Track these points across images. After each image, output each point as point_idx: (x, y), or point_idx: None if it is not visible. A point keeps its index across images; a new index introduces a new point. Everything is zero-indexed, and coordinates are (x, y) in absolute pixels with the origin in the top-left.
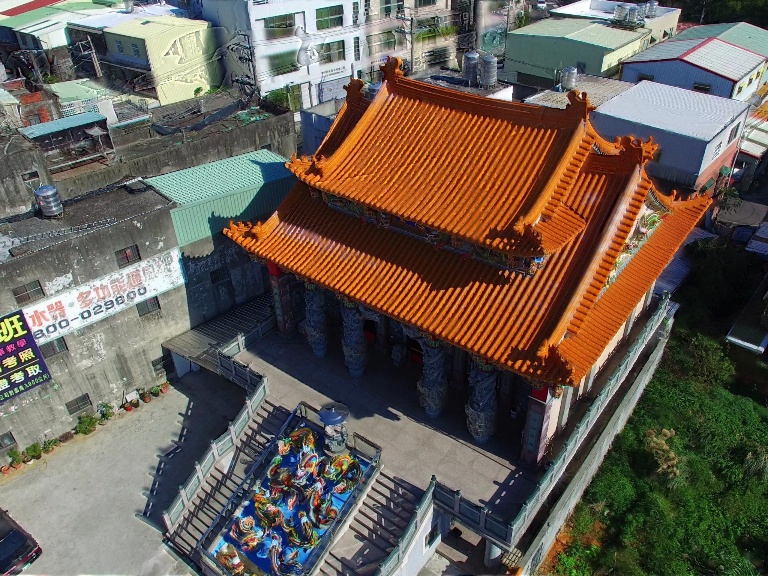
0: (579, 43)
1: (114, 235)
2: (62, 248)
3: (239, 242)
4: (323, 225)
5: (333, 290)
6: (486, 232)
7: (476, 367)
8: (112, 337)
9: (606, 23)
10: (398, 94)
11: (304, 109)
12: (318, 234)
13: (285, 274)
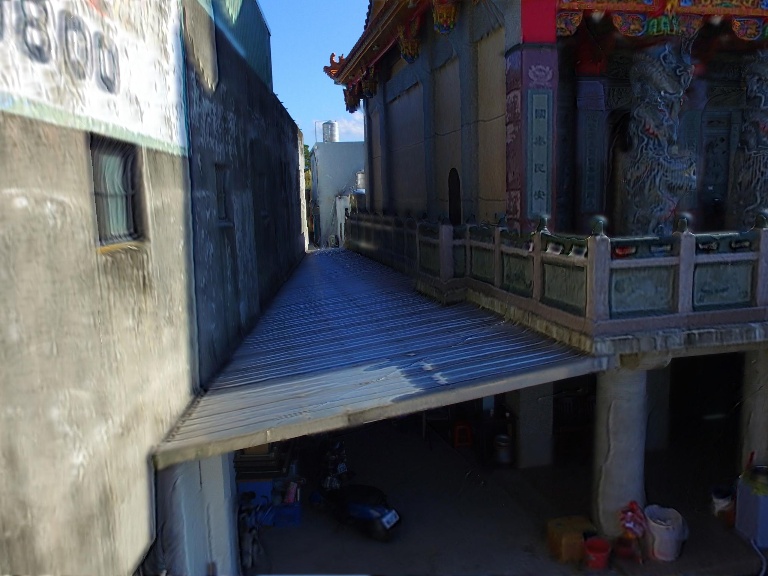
0: None
1: None
2: None
3: None
4: None
5: (743, 9)
6: None
7: None
8: None
9: None
10: None
11: None
12: None
13: None
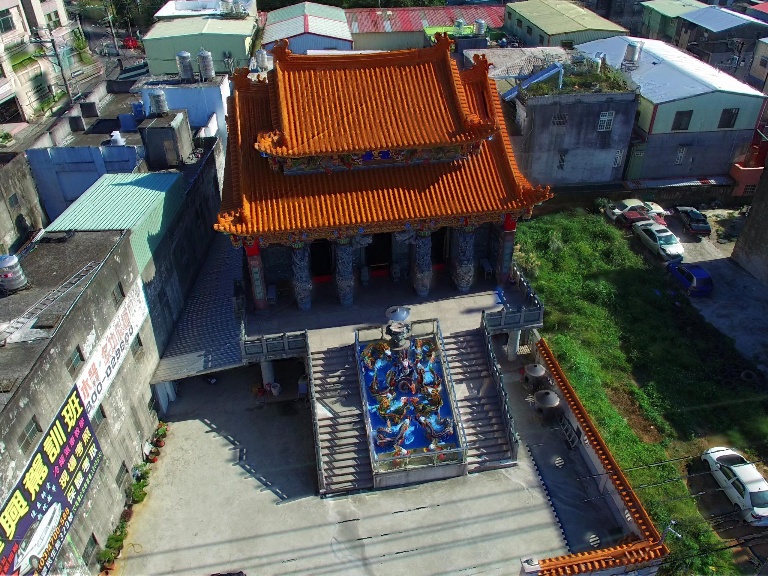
0: (219, 35)
1: (107, 276)
2: (84, 302)
3: (234, 231)
4: (294, 189)
5: (327, 236)
6: (446, 135)
7: (463, 233)
8: (125, 390)
9: (217, 17)
10: (291, 70)
11: (28, 148)
12: (296, 197)
13: (260, 251)
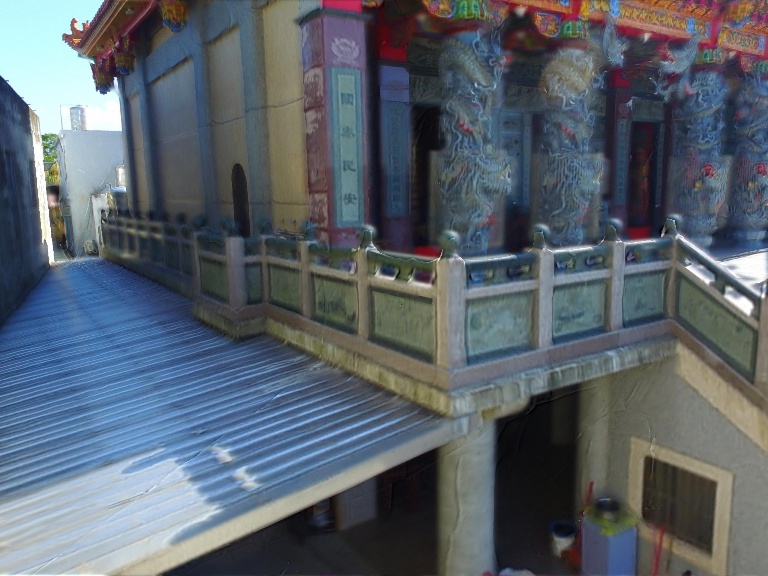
0: None
1: None
2: None
3: None
4: None
5: (545, 2)
6: None
7: (761, 79)
8: None
9: None
10: None
11: None
12: None
13: None
